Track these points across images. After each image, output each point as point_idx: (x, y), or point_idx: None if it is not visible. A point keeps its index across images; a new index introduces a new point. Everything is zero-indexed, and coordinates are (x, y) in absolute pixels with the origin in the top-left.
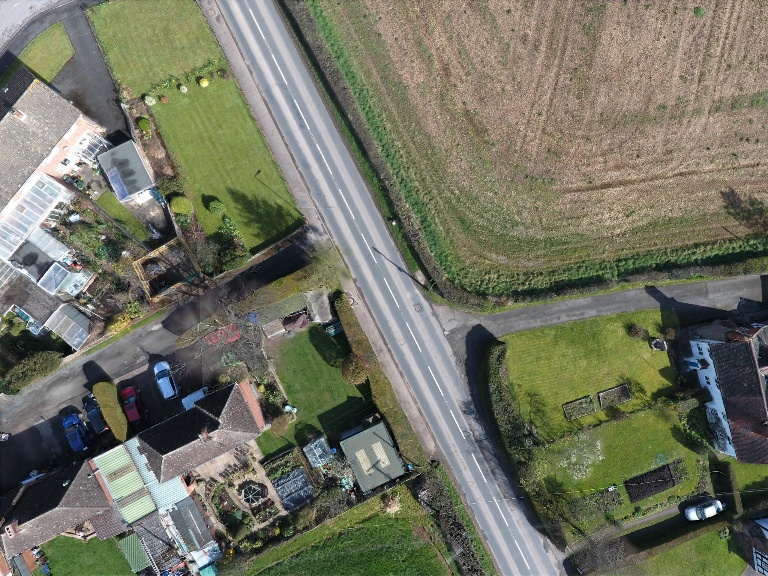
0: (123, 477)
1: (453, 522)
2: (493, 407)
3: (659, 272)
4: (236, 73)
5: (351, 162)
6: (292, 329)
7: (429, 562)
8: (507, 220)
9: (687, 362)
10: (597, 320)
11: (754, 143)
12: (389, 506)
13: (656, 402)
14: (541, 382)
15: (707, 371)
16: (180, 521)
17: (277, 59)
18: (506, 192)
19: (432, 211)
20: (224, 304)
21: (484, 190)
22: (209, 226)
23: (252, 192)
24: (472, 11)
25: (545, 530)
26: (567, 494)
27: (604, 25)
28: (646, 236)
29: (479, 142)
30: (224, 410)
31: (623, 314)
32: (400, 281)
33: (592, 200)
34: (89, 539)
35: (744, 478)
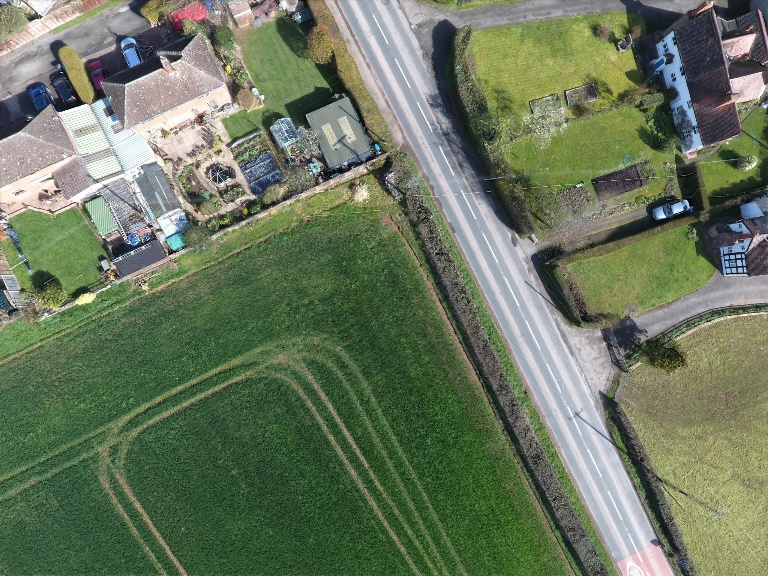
0: (89, 135)
1: (420, 205)
2: (459, 88)
3: None
4: None
5: None
6: (259, 15)
7: (397, 251)
8: None
9: (653, 66)
10: (563, 20)
11: None
12: (356, 190)
13: (623, 102)
14: (508, 79)
15: (672, 65)
16: (146, 186)
17: None
18: None
19: None
20: None
21: None
22: None
23: None
24: None
25: (512, 221)
26: (534, 189)
27: None
28: None
29: None
30: (187, 47)
31: (589, 15)
32: None
33: None
34: (57, 214)
35: (711, 183)
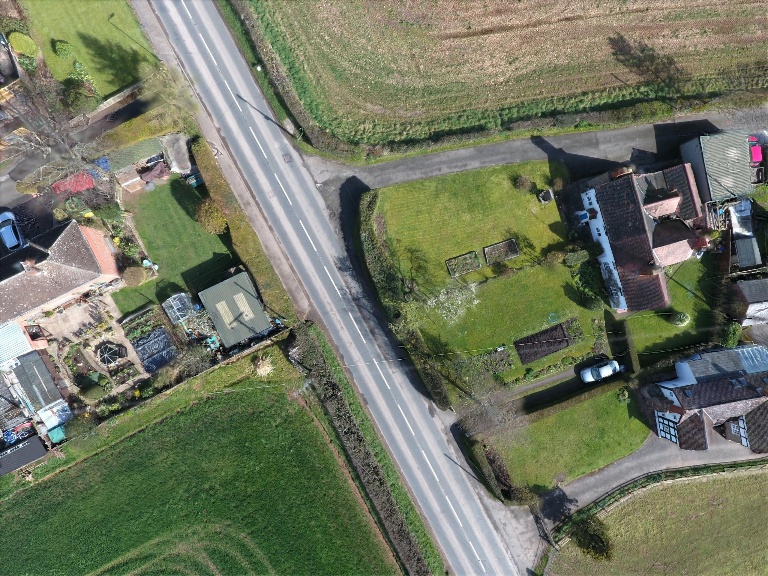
0: None
1: (327, 381)
2: (365, 257)
3: (543, 118)
4: None
5: (212, 5)
6: (150, 180)
7: (305, 428)
8: (382, 67)
9: (579, 216)
10: (480, 172)
11: None
12: (258, 366)
13: (546, 257)
14: (422, 237)
15: (597, 221)
16: (24, 377)
17: None
18: (380, 38)
19: (300, 57)
20: (68, 145)
21: (357, 36)
22: (60, 72)
23: (105, 36)
24: None
25: None
26: (452, 354)
27: None
28: (531, 84)
29: None
30: (55, 243)
31: (508, 165)
32: (267, 130)
33: (472, 47)
34: None
35: (644, 339)
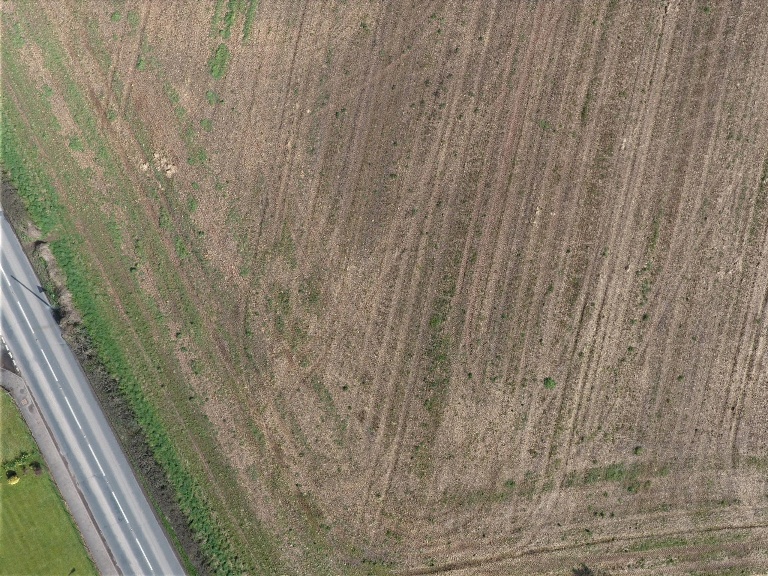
0: None
1: None
2: None
3: None
4: (50, 466)
5: (173, 556)
6: None
7: None
8: None
9: None
10: None
11: (609, 517)
12: None
13: None
14: None
15: None
16: None
17: (94, 449)
18: None
19: None
20: None
21: None
22: None
23: None
24: (306, 388)
25: None
26: None
27: (447, 400)
28: None
29: (313, 525)
30: None
31: None
32: None
33: None
34: None
35: None
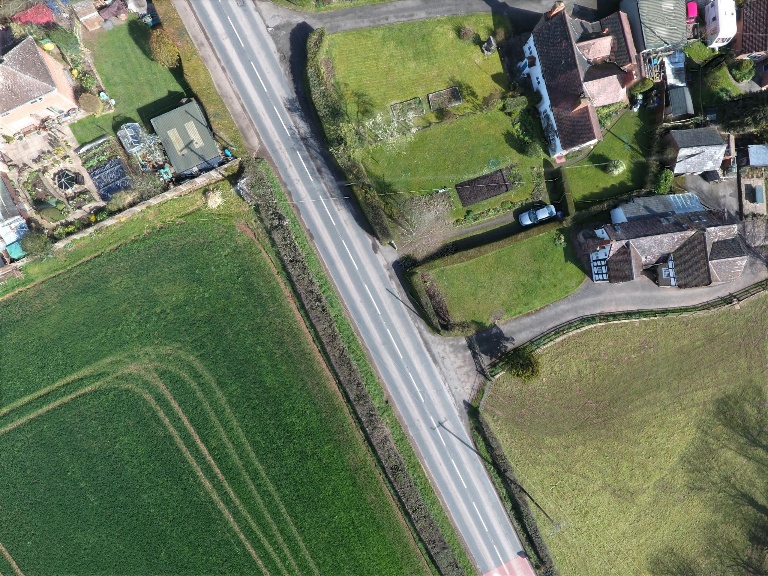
0: None
1: (273, 211)
2: (311, 92)
3: None
4: None
5: None
6: (108, 17)
7: (253, 258)
8: None
9: (521, 69)
10: (426, 22)
11: None
12: (208, 197)
13: (487, 105)
14: (369, 82)
15: (536, 68)
16: None
17: None
18: None
19: None
20: None
21: None
22: None
23: None
24: None
25: (372, 228)
26: (395, 194)
27: None
28: None
29: None
30: (11, 51)
31: (453, 17)
32: None
33: None
34: None
35: (581, 188)
